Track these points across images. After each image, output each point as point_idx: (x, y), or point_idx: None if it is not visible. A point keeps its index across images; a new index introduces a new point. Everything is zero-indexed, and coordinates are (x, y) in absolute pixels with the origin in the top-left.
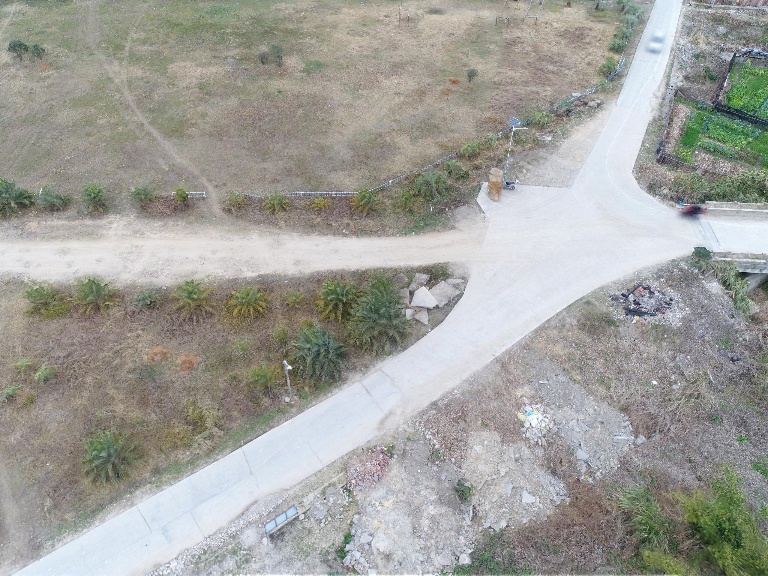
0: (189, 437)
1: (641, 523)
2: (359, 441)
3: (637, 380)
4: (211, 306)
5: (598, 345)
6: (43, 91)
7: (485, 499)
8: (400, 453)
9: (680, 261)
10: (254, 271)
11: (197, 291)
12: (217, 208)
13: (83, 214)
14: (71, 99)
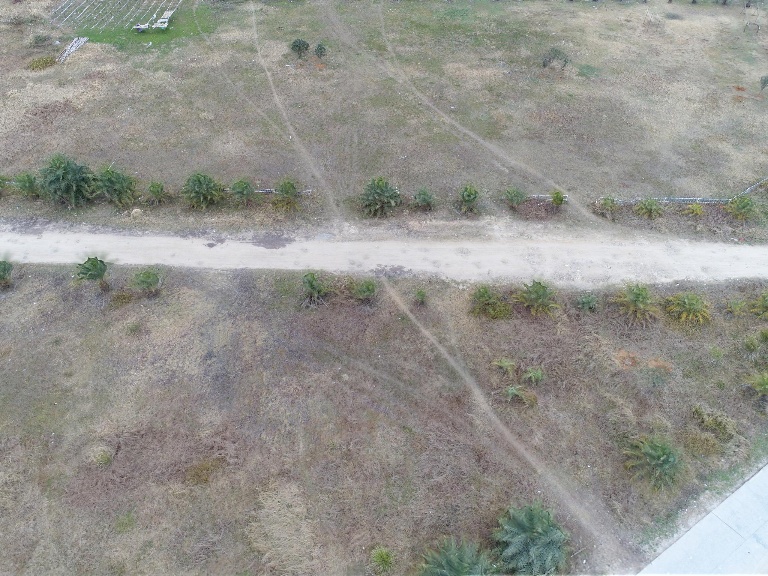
0: (718, 444)
1: None
2: None
3: None
4: None
5: None
6: (334, 90)
7: None
8: None
9: None
10: (667, 277)
11: (648, 296)
12: (586, 212)
13: (457, 214)
14: (367, 99)
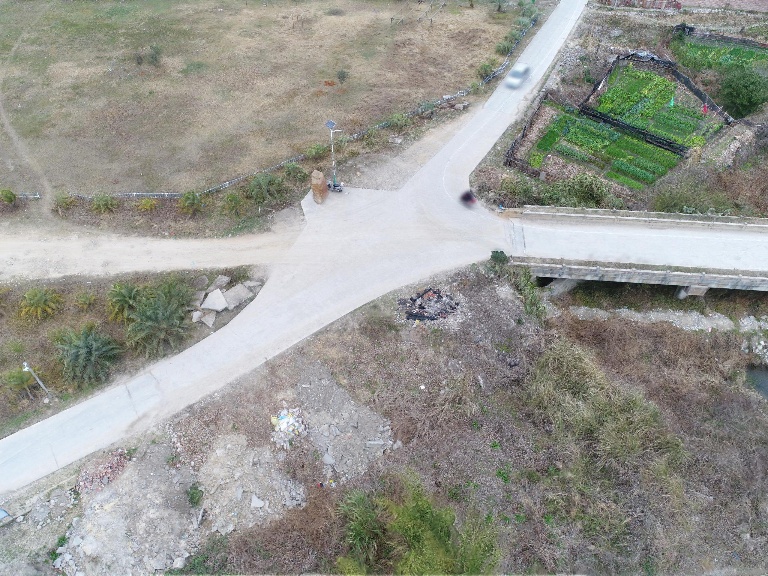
0: None
1: (349, 529)
2: (103, 443)
3: (406, 385)
4: (3, 307)
5: (376, 349)
6: None
7: (217, 503)
8: (140, 456)
9: (479, 265)
10: (60, 272)
11: None
12: (47, 209)
13: None
14: None
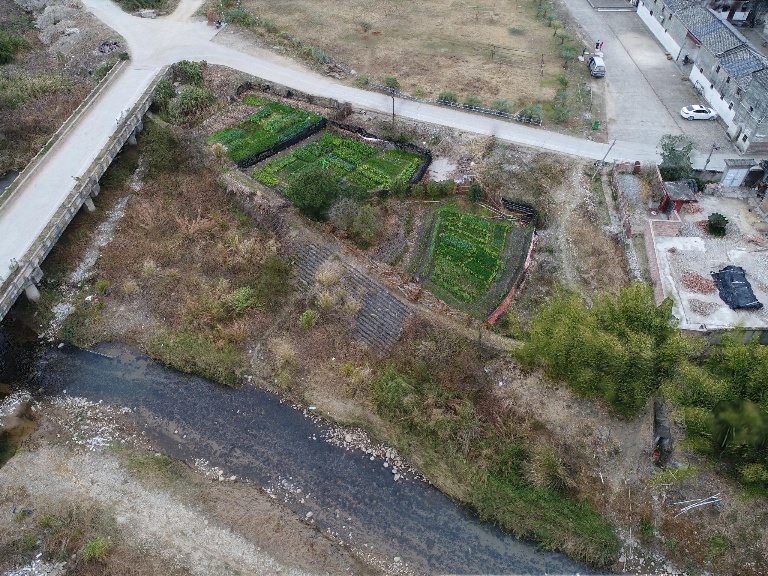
0: None
1: None
2: (86, 4)
3: None
4: None
5: None
6: None
7: None
8: None
9: None
10: None
11: None
12: None
13: None
14: None
